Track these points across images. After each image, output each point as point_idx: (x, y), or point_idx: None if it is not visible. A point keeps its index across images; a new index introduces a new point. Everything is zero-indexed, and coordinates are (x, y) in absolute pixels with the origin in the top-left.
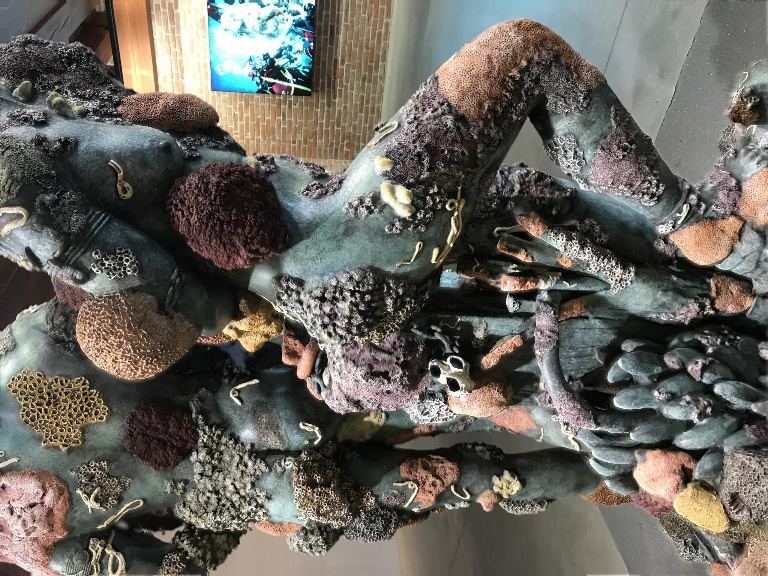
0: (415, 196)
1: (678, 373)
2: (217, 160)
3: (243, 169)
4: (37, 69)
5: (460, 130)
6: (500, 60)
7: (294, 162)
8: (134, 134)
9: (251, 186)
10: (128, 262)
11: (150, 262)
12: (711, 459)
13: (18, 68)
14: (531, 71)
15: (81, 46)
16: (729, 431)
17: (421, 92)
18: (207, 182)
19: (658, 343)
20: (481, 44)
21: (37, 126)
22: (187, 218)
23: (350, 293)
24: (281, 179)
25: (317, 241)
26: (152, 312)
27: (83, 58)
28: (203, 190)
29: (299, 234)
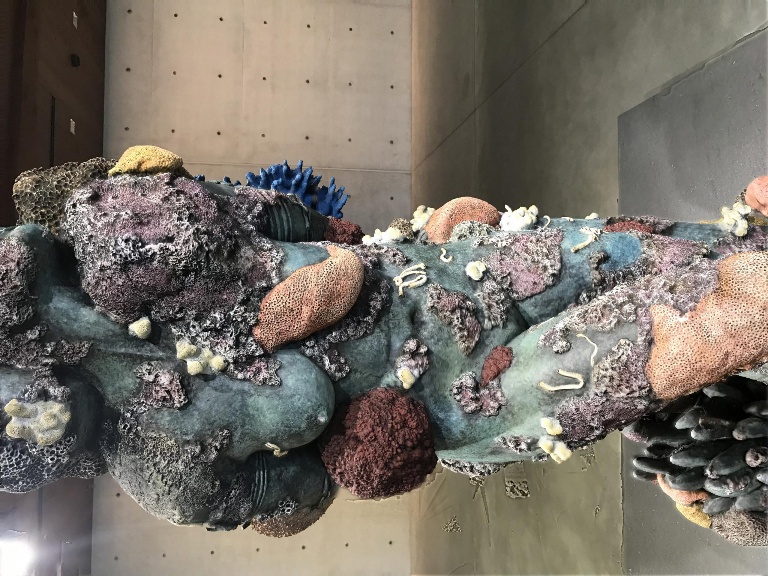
0: (573, 447)
1: (738, 444)
2: (367, 364)
3: (404, 438)
4: (151, 298)
5: (649, 405)
6: (738, 360)
7: (447, 323)
8: (289, 411)
9: (411, 456)
10: (290, 511)
11: (306, 493)
12: (722, 505)
13: (128, 304)
14: (767, 361)
15: (196, 245)
16: (749, 493)
17: (625, 353)
18: (370, 471)
19: (739, 390)
20: (727, 330)
21: (180, 408)
22: (346, 484)
23: (480, 473)
24: (434, 378)
25: (461, 453)
26: (307, 516)
27: (202, 264)
28: (365, 478)
29: (445, 446)
